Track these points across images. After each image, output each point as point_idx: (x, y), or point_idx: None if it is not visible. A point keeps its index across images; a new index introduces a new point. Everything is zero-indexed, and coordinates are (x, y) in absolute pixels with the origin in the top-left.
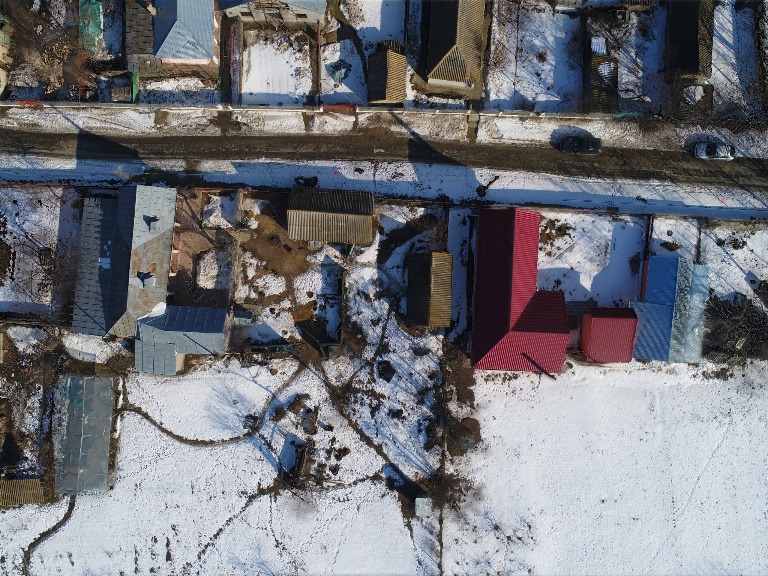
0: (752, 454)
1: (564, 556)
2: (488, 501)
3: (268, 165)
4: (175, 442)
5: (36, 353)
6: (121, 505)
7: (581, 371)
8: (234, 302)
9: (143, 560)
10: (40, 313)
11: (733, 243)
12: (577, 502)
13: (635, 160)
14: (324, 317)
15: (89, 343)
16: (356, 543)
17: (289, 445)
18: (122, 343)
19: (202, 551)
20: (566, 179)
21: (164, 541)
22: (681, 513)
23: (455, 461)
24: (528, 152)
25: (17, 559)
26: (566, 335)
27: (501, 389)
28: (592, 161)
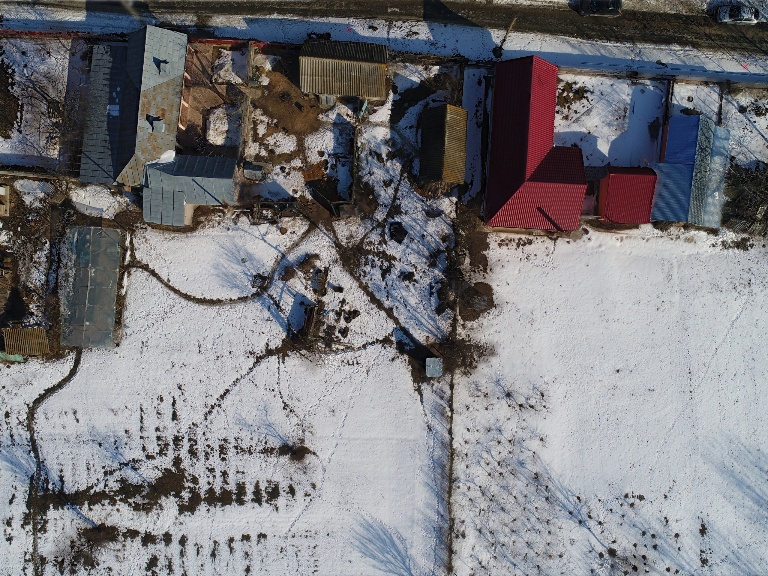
0: None
1: (577, 426)
2: (500, 368)
3: (280, 21)
4: (182, 300)
5: (43, 207)
6: (127, 362)
7: (597, 237)
8: (244, 159)
9: (149, 419)
10: (47, 167)
11: (755, 110)
12: (591, 371)
13: (656, 24)
14: (335, 176)
15: (97, 198)
16: (365, 407)
17: (298, 306)
18: (130, 198)
19: (208, 411)
20: (584, 42)
21: (170, 400)
22: (698, 385)
23: (467, 326)
24: (546, 14)
25: (21, 415)
26: (583, 186)
27: (515, 254)
28: (611, 24)
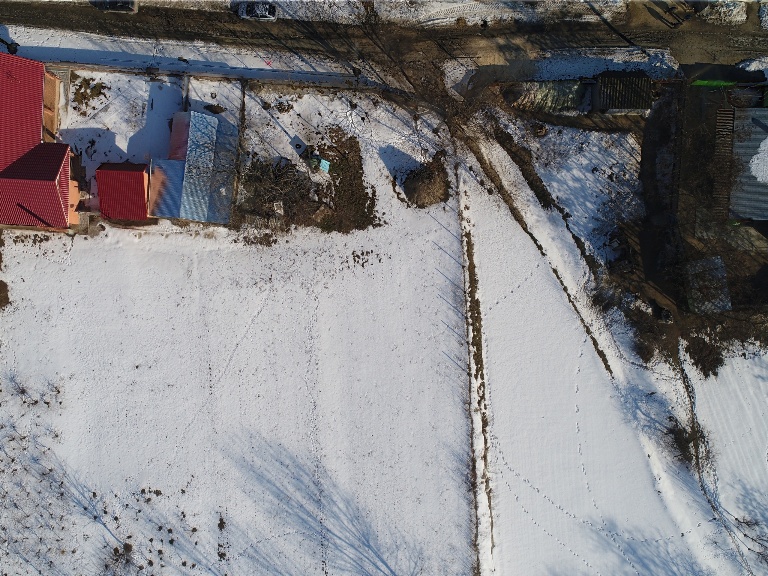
0: (293, 321)
1: (95, 422)
2: (15, 365)
3: None
4: None
5: None
6: None
7: (114, 233)
8: None
9: None
10: None
11: (278, 106)
12: (109, 367)
13: (179, 20)
14: None
15: None
16: None
17: None
18: None
19: None
20: (106, 39)
21: None
22: (218, 380)
23: None
24: (67, 10)
25: None
26: (51, 182)
27: (31, 251)
28: (135, 21)
